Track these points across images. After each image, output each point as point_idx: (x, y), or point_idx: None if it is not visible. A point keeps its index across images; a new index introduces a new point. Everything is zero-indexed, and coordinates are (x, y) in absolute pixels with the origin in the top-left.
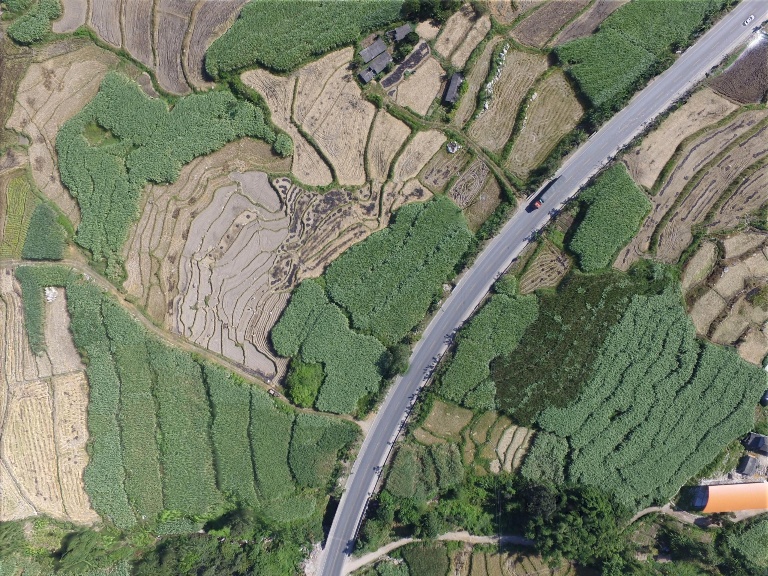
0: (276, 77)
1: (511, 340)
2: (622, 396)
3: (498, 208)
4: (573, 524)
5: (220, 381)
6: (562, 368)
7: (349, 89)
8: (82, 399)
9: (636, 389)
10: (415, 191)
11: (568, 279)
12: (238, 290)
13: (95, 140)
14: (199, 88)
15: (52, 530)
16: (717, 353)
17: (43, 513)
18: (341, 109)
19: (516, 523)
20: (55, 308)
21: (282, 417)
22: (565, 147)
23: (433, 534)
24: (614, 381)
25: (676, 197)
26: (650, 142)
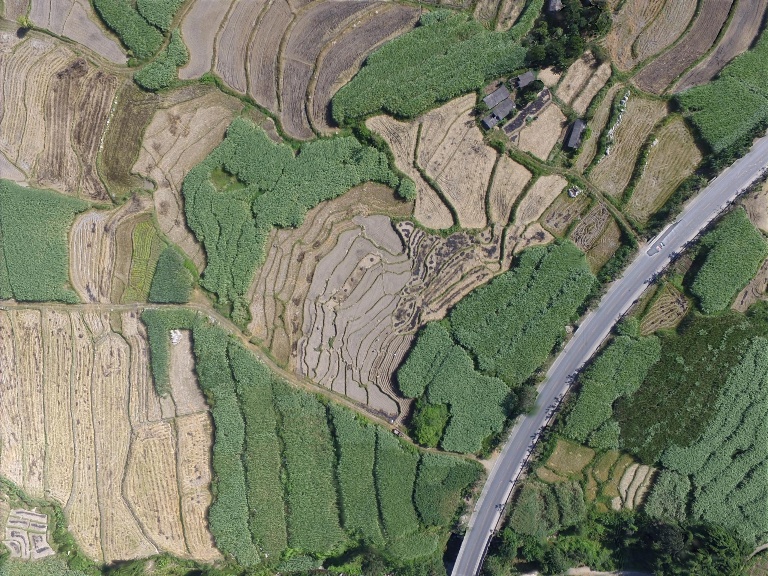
0: (400, 123)
1: (634, 381)
2: (743, 435)
3: (619, 251)
4: (702, 562)
5: (346, 422)
6: (684, 408)
7: (472, 134)
8: (205, 439)
9: (757, 428)
10: (537, 234)
11: (689, 321)
12: (362, 332)
13: (220, 185)
14: (323, 133)
15: (173, 568)
16: None
17: (165, 552)
18: (464, 154)
19: (639, 559)
20: (179, 350)
21: (407, 457)
22: (686, 192)
23: (559, 571)
24: (735, 420)
25: None
26: (767, 187)
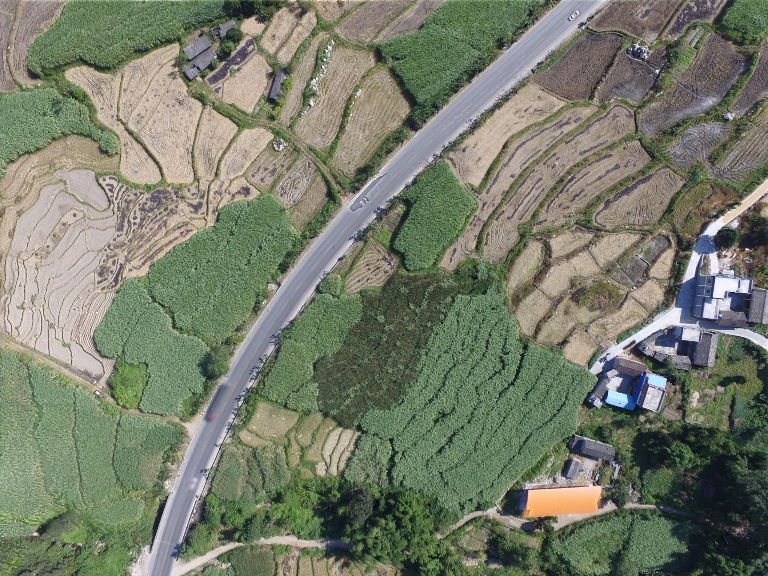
0: (101, 74)
1: (334, 341)
2: (445, 398)
3: (324, 206)
4: (386, 528)
5: (43, 382)
6: (385, 369)
7: (175, 86)
8: None
9: (459, 391)
10: (242, 189)
11: (392, 279)
12: (64, 289)
13: None
14: (25, 85)
15: None
16: (539, 354)
17: None
18: (167, 106)
19: (340, 527)
20: None
21: (106, 418)
22: (389, 144)
23: (255, 538)
24: (437, 382)
25: (503, 195)
26: (476, 139)
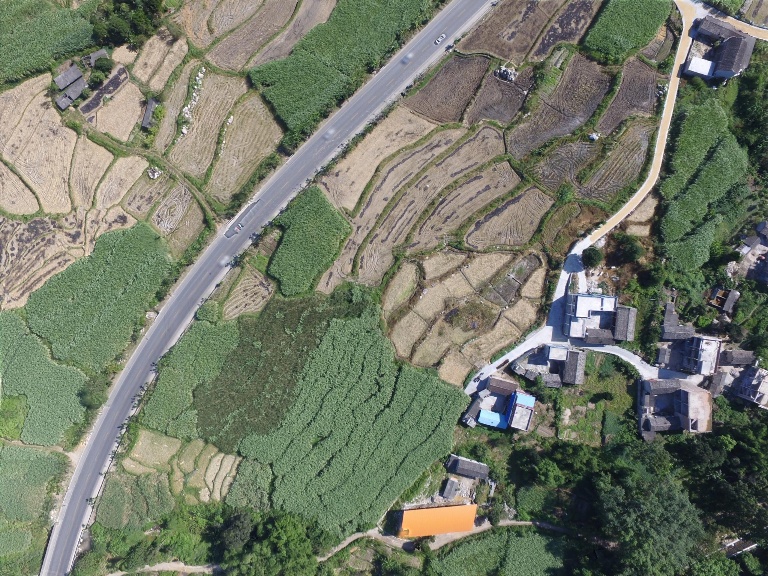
0: None
1: (212, 367)
2: (322, 421)
3: (200, 233)
4: (262, 554)
5: None
6: (263, 394)
7: (49, 116)
8: None
9: (335, 414)
10: (118, 218)
11: (268, 304)
12: None
13: None
14: None
15: None
16: (413, 376)
17: None
18: (41, 136)
19: None
20: None
21: None
22: (261, 171)
23: (138, 566)
24: (314, 406)
25: (376, 218)
26: (349, 164)
